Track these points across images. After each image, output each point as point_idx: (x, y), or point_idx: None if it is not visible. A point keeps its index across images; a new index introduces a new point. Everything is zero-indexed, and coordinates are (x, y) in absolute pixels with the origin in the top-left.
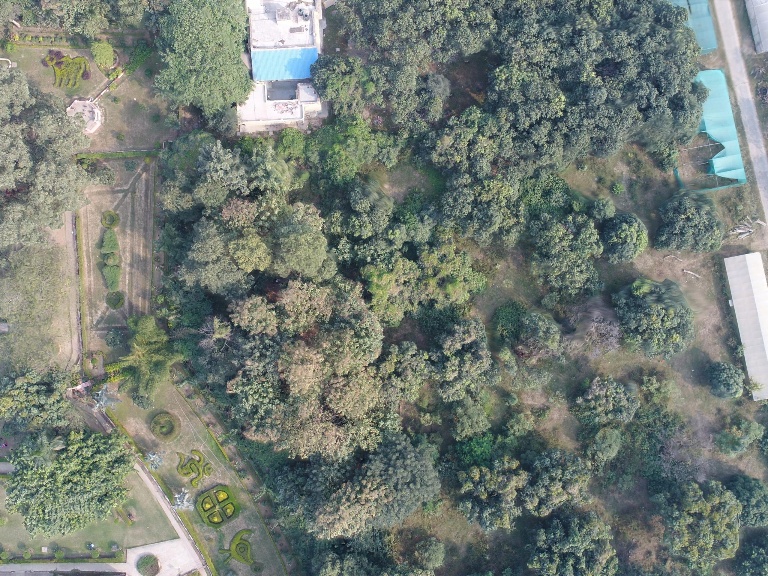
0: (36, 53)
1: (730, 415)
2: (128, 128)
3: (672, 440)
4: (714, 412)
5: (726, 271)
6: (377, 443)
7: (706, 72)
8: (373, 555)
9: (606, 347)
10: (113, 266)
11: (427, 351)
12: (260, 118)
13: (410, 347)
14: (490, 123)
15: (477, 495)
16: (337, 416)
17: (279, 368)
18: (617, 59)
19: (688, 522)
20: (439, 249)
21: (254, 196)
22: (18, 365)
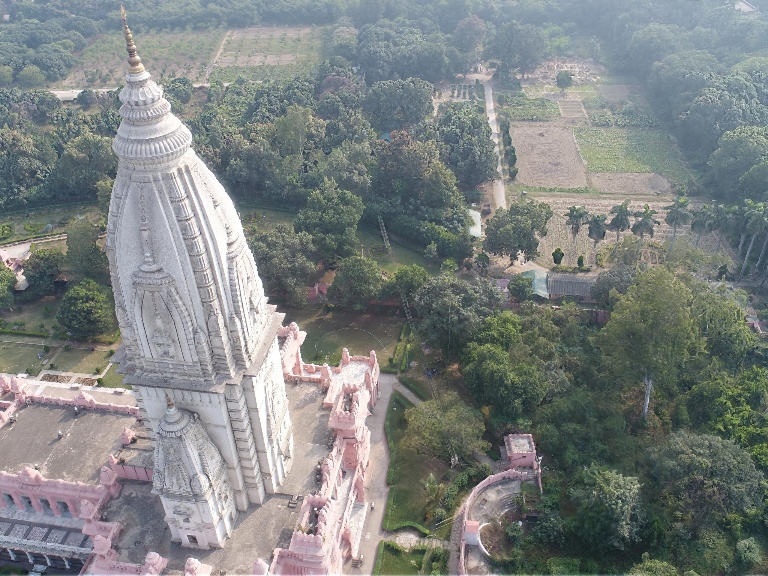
0: None
1: None
2: None
3: None
4: None
5: None
6: None
7: None
8: None
9: None
10: None
11: None
12: None
13: None
14: None
15: None
16: None
17: None
18: None
19: None
20: None
21: None
22: None
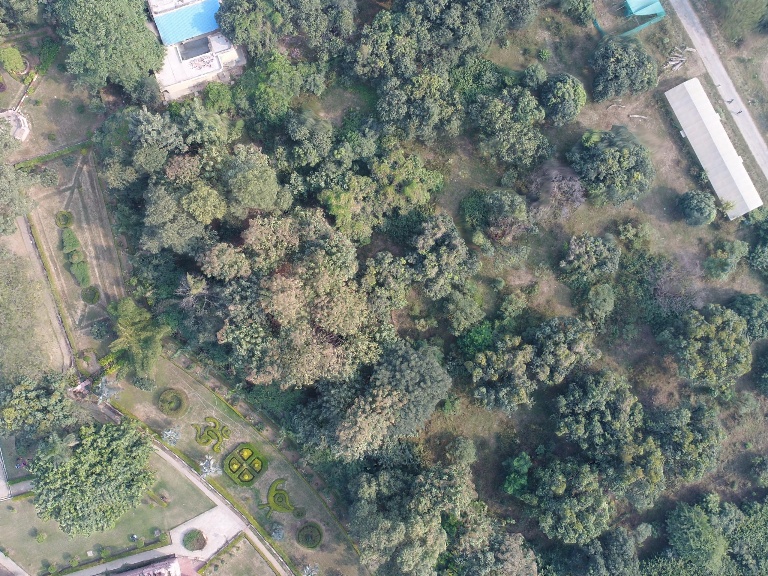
0: None
1: (712, 241)
2: (57, 127)
3: (662, 277)
4: (696, 243)
5: (670, 104)
6: (379, 355)
7: None
8: (407, 469)
9: (573, 204)
10: (79, 263)
11: (403, 257)
12: (180, 80)
13: (385, 256)
14: (402, 21)
15: (490, 382)
16: (332, 338)
17: (262, 304)
18: None
19: (697, 348)
20: (388, 158)
21: (194, 151)
22: (11, 376)
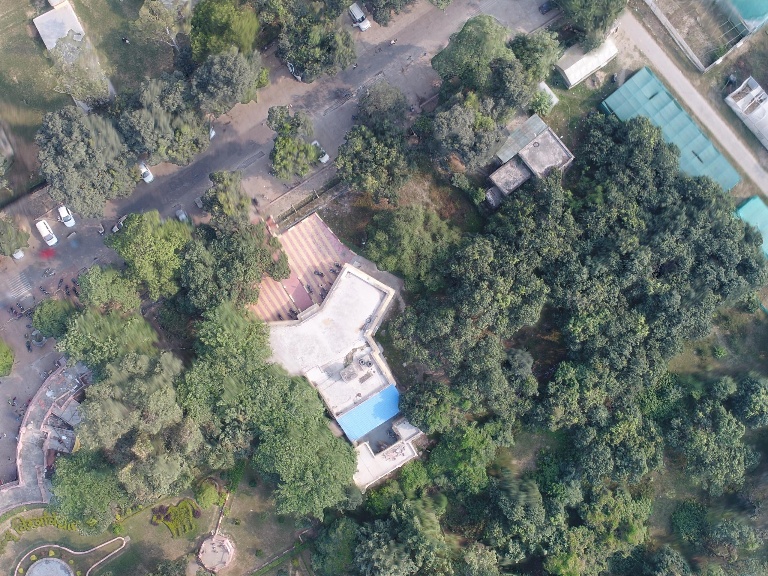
0: (141, 518)
1: None
2: (260, 540)
3: None
4: None
5: None
6: None
7: (744, 208)
8: None
9: None
10: None
11: None
12: (377, 475)
13: None
14: (589, 375)
15: None
16: None
17: None
18: (672, 259)
19: None
20: (599, 503)
21: (423, 567)
22: None
